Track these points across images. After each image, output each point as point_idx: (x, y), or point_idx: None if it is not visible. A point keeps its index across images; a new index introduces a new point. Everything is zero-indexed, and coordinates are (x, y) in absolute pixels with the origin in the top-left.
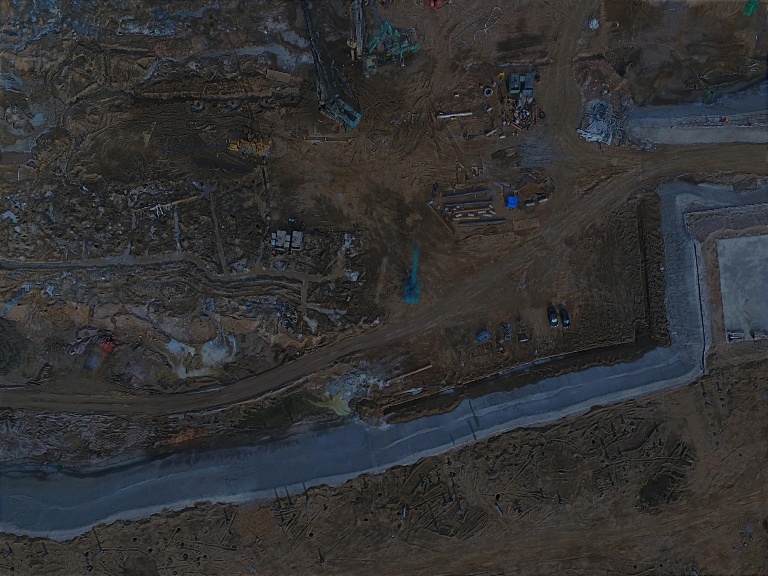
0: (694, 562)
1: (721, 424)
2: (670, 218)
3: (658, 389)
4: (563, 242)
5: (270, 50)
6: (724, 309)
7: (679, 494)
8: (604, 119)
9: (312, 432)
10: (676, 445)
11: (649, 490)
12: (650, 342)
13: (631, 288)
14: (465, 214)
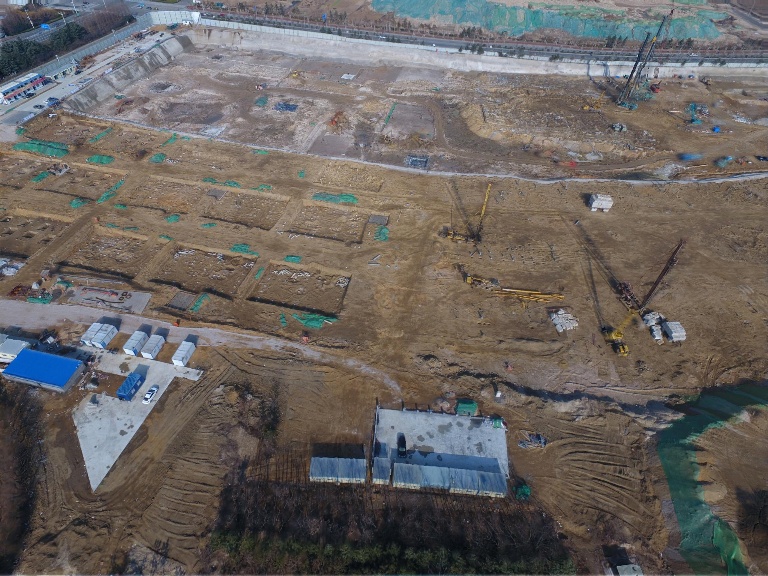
0: None
1: None
2: None
3: None
4: (748, 142)
5: None
6: None
7: None
8: None
9: None
10: None
11: None
12: None
13: None
14: None
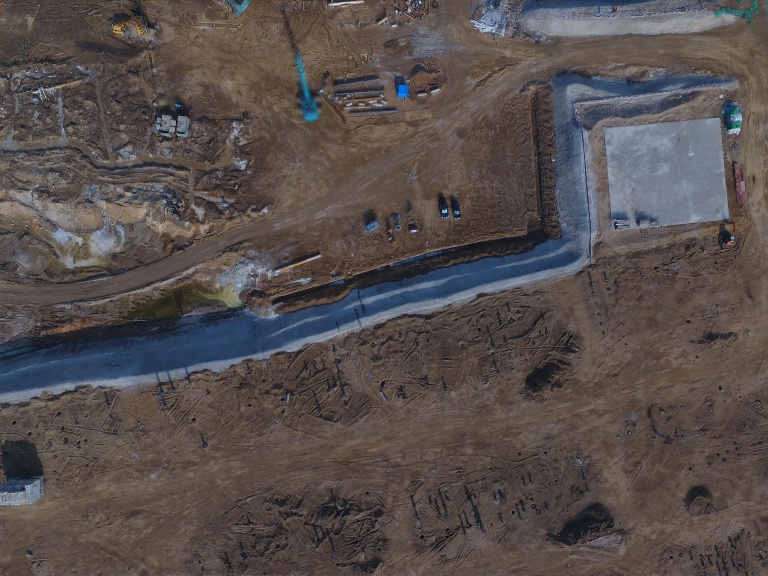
0: (578, 450)
1: (607, 313)
2: (561, 109)
3: (545, 278)
4: (455, 133)
5: None
6: (611, 197)
7: (564, 382)
8: (498, 10)
9: (201, 323)
10: (562, 334)
11: (534, 377)
12: (542, 235)
13: (523, 180)
14: (356, 103)
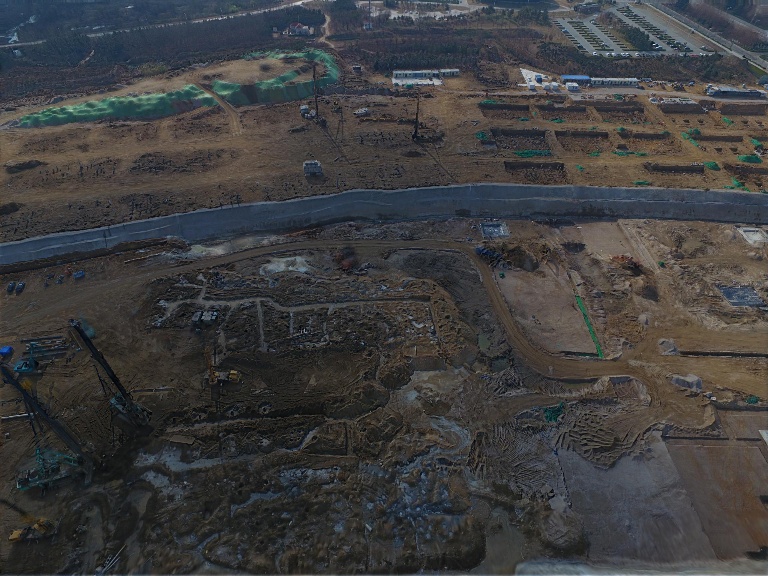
0: (6, 189)
1: None
2: None
3: None
4: None
5: (185, 465)
6: None
7: None
8: None
9: (218, 237)
10: None
11: (11, 210)
12: None
13: None
14: (53, 343)
